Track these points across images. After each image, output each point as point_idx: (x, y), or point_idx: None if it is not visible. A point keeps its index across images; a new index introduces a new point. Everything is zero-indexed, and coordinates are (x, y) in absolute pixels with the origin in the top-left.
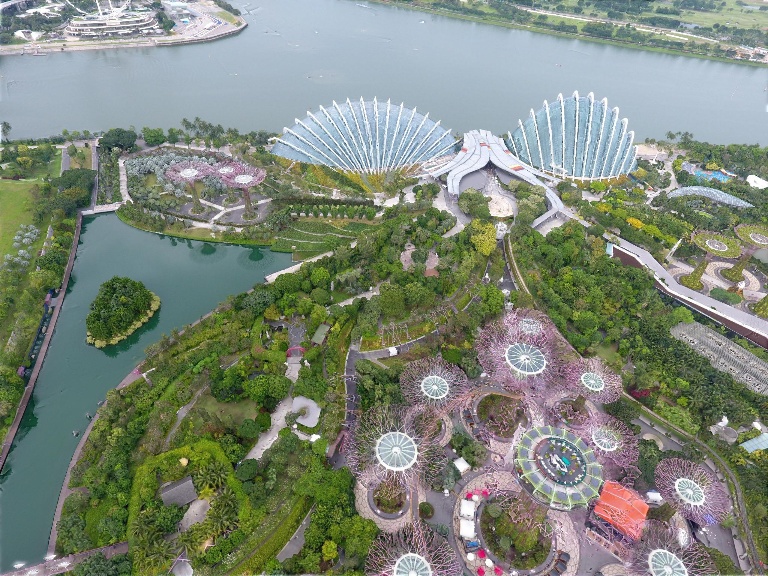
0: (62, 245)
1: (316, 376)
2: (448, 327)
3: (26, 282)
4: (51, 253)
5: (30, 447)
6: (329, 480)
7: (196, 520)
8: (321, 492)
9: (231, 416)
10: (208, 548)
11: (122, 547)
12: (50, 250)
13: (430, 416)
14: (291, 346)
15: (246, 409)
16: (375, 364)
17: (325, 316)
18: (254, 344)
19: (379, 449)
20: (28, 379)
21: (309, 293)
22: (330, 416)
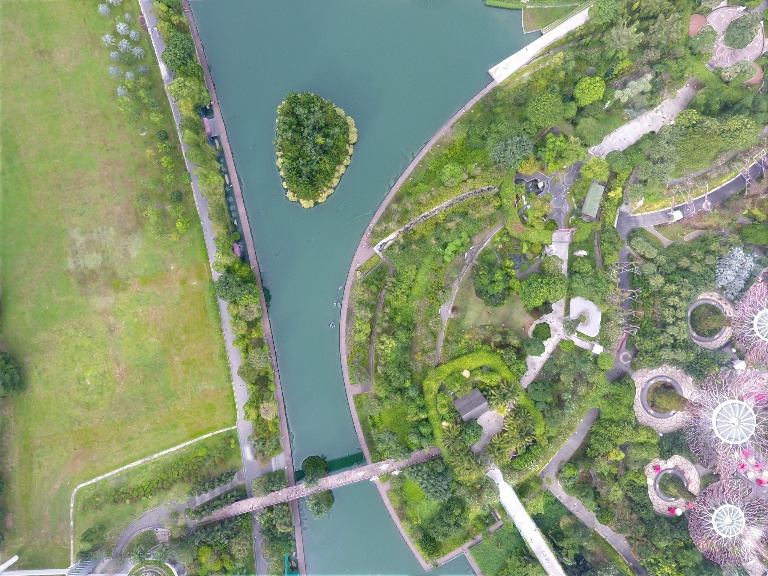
0: (171, 7)
1: (595, 271)
2: (762, 185)
3: (159, 90)
4: (178, 43)
5: (277, 322)
6: (618, 398)
7: (489, 426)
8: (612, 411)
9: (519, 340)
10: (513, 458)
11: (432, 449)
12: (172, 35)
13: (762, 366)
14: (552, 215)
15: (514, 308)
16: (651, 235)
17: (603, 175)
18: (511, 218)
19: (717, 421)
20: (247, 256)
21: (571, 121)
22: (615, 326)
